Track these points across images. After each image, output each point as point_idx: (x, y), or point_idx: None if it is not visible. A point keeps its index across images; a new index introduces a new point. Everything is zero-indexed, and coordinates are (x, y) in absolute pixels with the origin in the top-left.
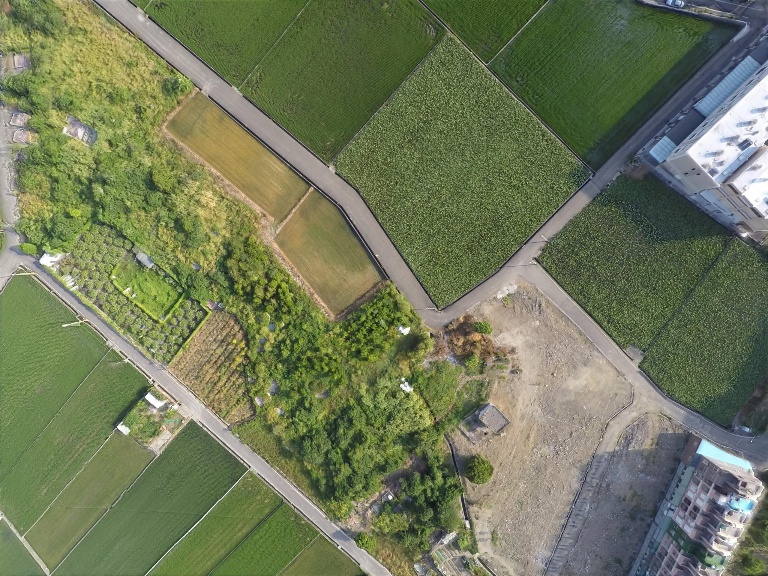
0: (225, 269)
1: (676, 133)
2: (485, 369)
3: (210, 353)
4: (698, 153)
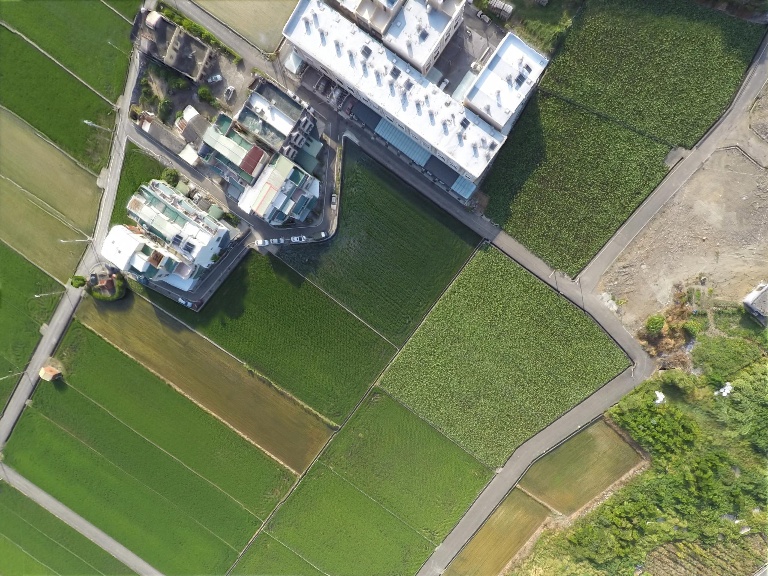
0: (604, 563)
1: (447, 178)
2: (701, 312)
3: (689, 573)
4: (475, 165)
